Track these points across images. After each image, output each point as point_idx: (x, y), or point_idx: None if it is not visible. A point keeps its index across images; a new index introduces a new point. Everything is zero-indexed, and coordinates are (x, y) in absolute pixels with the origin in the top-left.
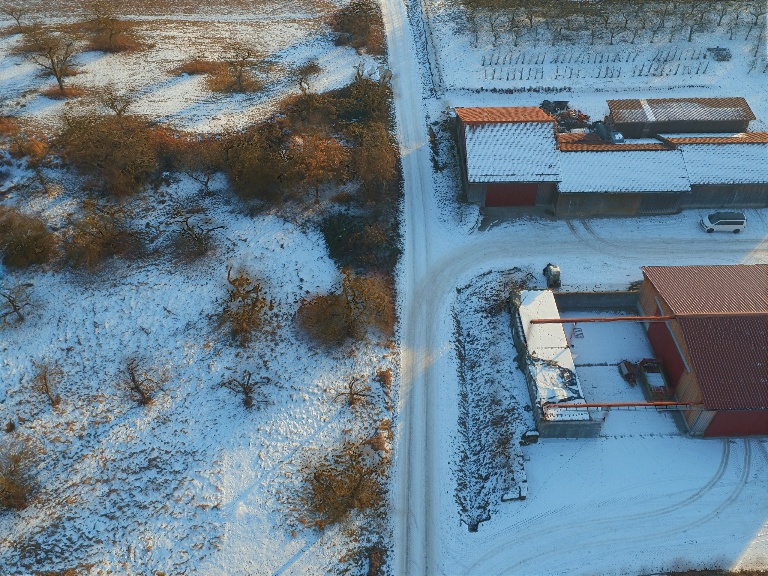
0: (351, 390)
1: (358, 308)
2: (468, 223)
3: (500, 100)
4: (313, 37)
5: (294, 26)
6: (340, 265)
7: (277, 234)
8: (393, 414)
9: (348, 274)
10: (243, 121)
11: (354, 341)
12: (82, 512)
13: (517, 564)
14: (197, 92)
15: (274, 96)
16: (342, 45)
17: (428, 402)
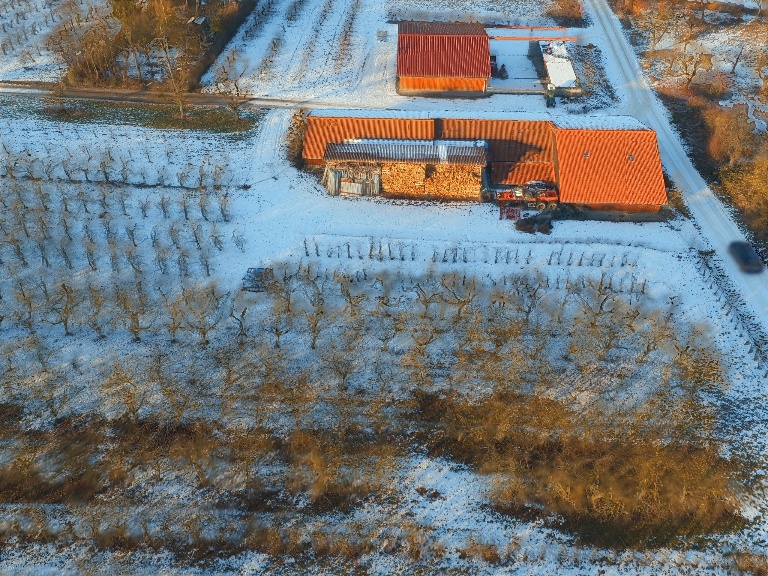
0: None
1: None
2: None
3: None
4: None
5: None
6: None
7: None
8: None
9: None
10: None
11: None
12: None
13: None
14: None
15: None
16: None
17: (624, 73)
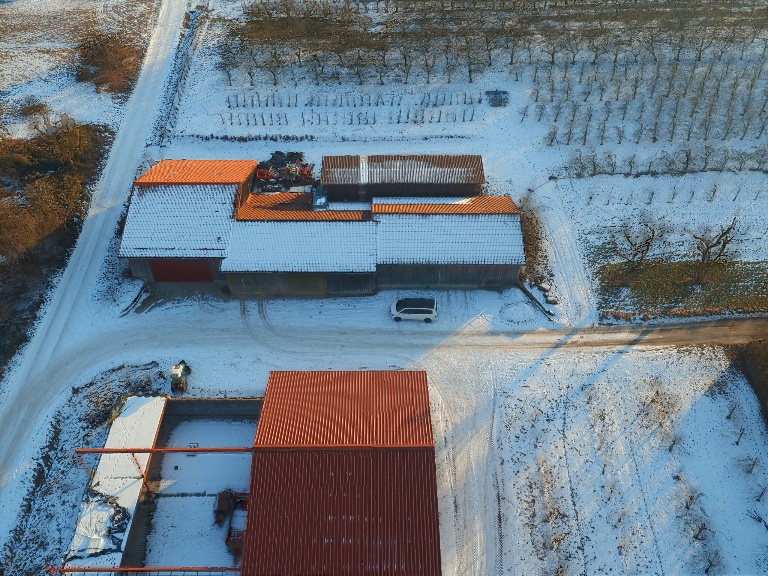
0: None
1: None
2: (121, 304)
3: (231, 149)
4: (57, 71)
5: (44, 57)
6: None
7: None
8: None
9: None
10: None
11: None
12: None
13: None
14: None
15: None
16: (84, 81)
17: None
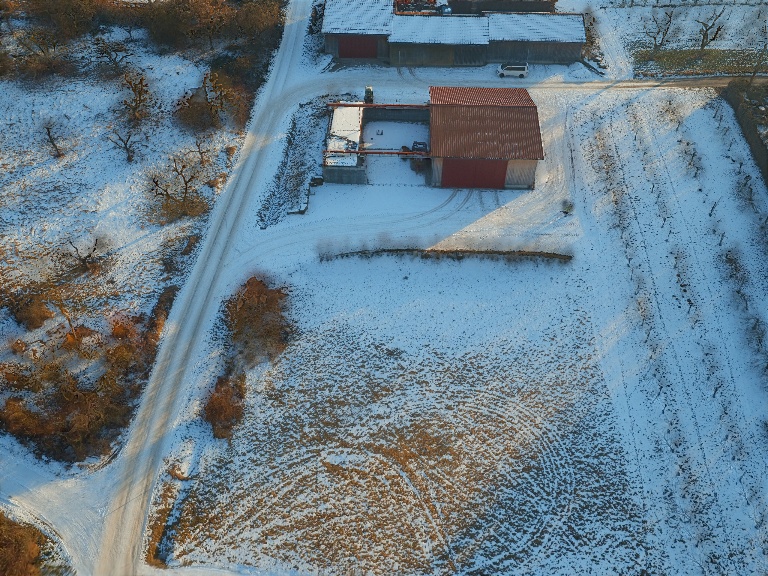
0: (199, 148)
1: (223, 111)
2: (321, 65)
3: None
4: None
5: None
6: (217, 86)
7: (176, 66)
8: (230, 170)
9: (221, 91)
10: None
11: (214, 129)
12: (4, 209)
13: (286, 245)
14: None
15: None
16: None
17: (257, 165)
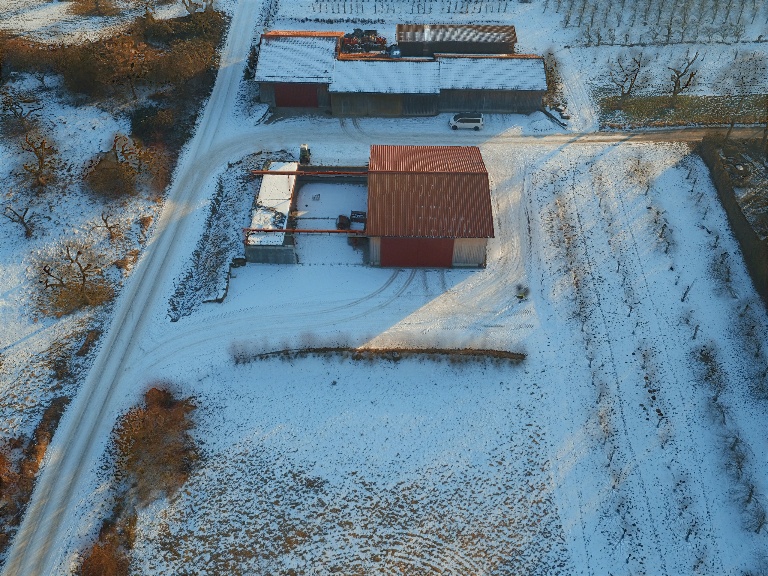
0: (106, 223)
1: None
2: (255, 117)
3: (321, 29)
4: None
5: None
6: (137, 143)
7: (92, 119)
8: (143, 246)
9: (141, 149)
10: (93, 37)
11: (129, 196)
12: None
13: (198, 342)
14: (61, 14)
15: (127, 20)
16: None
17: (174, 239)
